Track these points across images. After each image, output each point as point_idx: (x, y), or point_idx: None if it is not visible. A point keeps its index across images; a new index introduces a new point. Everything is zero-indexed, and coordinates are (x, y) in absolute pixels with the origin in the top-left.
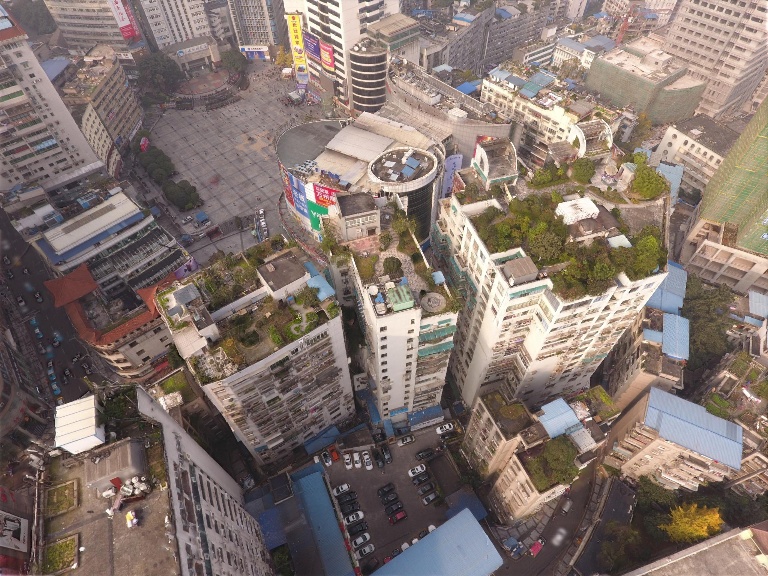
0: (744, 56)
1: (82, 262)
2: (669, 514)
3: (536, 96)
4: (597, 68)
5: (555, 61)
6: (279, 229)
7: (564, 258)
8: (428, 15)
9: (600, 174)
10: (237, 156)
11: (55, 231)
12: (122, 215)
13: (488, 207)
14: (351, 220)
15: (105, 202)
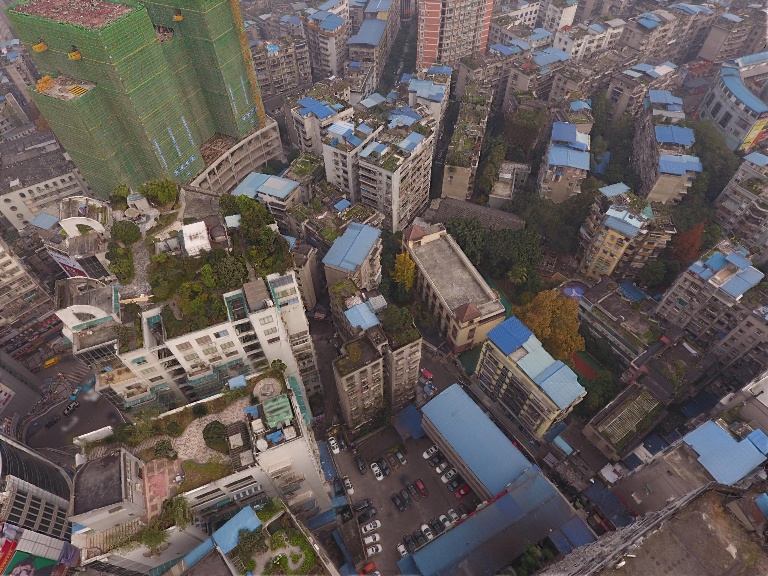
0: None
1: None
2: (398, 284)
3: None
4: None
5: None
6: None
7: None
8: None
9: None
10: None
11: None
12: None
13: (162, 316)
14: (126, 492)
15: None
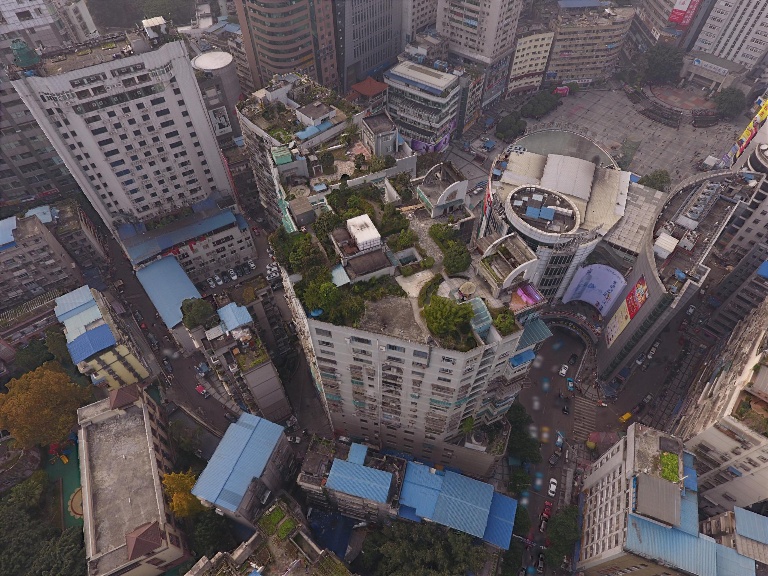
0: None
1: (395, 87)
2: None
3: None
4: None
5: None
6: None
7: None
8: None
9: None
10: None
11: (409, 63)
12: (432, 83)
13: None
14: None
15: (444, 73)
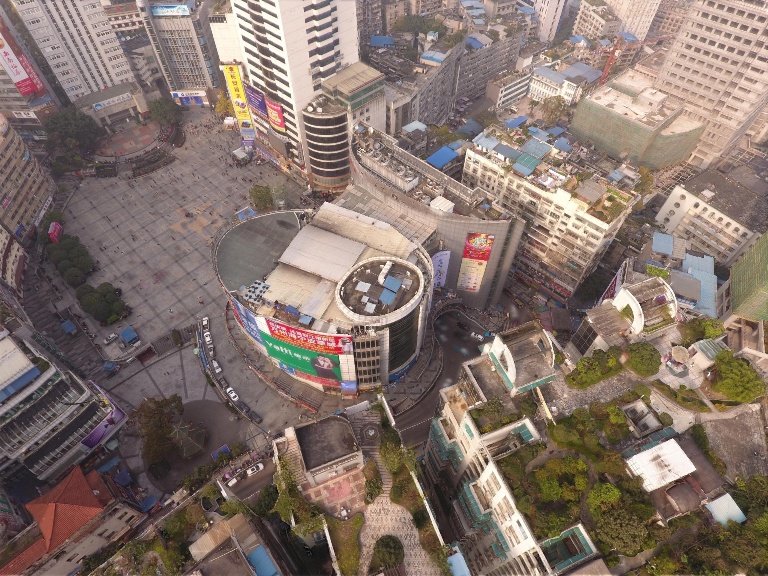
0: (749, 98)
1: None
2: None
3: (533, 173)
4: (585, 109)
5: (532, 92)
6: (228, 345)
7: (650, 548)
8: (390, 49)
9: (662, 354)
10: (173, 240)
11: None
12: (7, 378)
13: (523, 448)
14: None
15: None
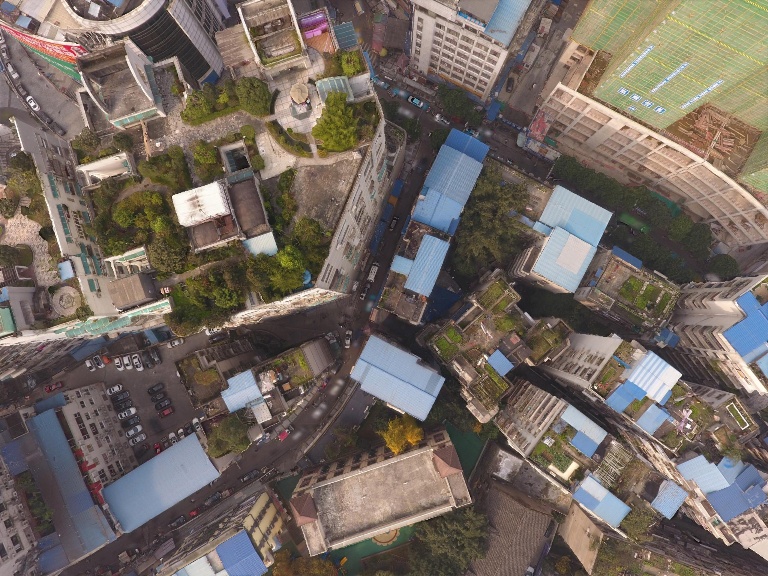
0: None
1: None
2: None
3: None
4: None
5: None
6: None
7: (190, 269)
8: None
9: None
10: None
11: None
12: None
13: None
14: None
15: None
